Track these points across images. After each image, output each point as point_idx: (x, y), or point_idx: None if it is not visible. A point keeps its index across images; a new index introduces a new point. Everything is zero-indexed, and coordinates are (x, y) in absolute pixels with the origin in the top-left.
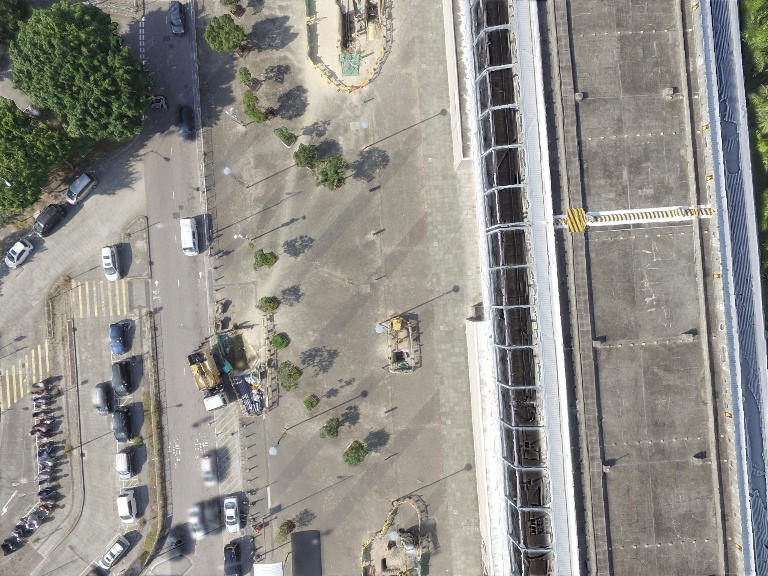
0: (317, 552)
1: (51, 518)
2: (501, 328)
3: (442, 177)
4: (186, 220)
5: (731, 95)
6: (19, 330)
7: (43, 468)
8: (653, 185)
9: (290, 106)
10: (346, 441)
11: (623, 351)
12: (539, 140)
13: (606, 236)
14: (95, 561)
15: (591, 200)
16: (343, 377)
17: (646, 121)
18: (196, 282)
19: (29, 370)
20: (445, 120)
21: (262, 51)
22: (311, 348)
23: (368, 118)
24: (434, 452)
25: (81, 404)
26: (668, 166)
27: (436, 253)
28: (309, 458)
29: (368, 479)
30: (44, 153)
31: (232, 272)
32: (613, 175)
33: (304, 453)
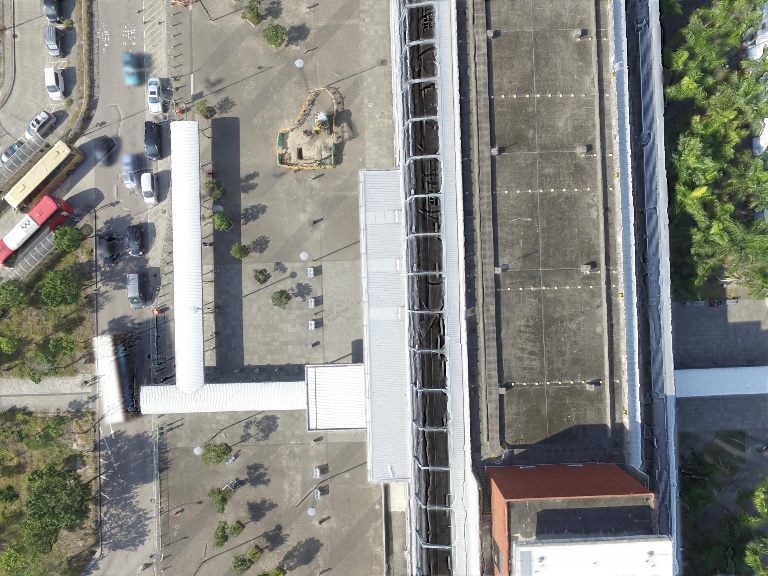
0: (236, 138)
1: None
2: None
3: None
4: None
5: None
6: None
7: None
8: None
9: None
10: None
11: None
12: None
13: None
14: (22, 137)
15: None
16: None
17: None
18: None
19: None
20: None
21: None
22: None
23: None
24: (352, 47)
25: None
26: None
27: None
28: (232, 49)
29: (288, 71)
30: None
31: None
32: None
33: (227, 44)
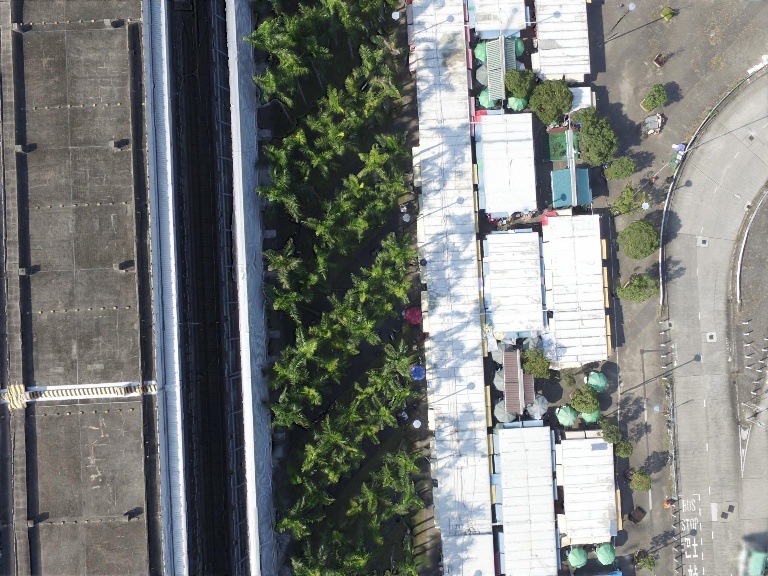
0: None
1: None
2: None
3: None
4: None
5: (233, 256)
6: None
7: None
8: (103, 360)
9: None
10: None
11: (66, 528)
12: None
13: (53, 411)
14: None
15: (39, 374)
16: None
17: (99, 295)
18: None
19: None
20: None
21: None
22: None
23: None
24: None
25: None
26: (120, 341)
27: None
28: None
29: None
30: None
31: None
32: (62, 349)
33: None
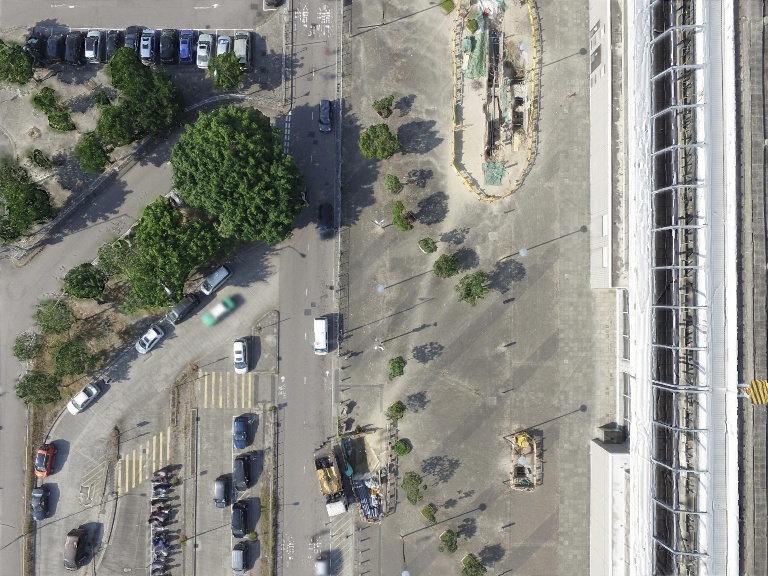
0: None
1: None
2: (649, 472)
3: (577, 294)
4: (321, 321)
5: None
6: (143, 415)
7: (157, 557)
8: None
9: (430, 211)
10: (461, 553)
11: None
12: (725, 306)
13: None
14: None
15: None
16: (463, 488)
17: None
18: (322, 381)
19: (149, 456)
20: (584, 237)
21: (406, 154)
22: (433, 456)
23: (507, 229)
24: (549, 572)
25: (198, 494)
26: None
27: (566, 370)
28: (422, 567)
29: None
30: (196, 253)
31: (359, 373)
32: None
33: (418, 562)
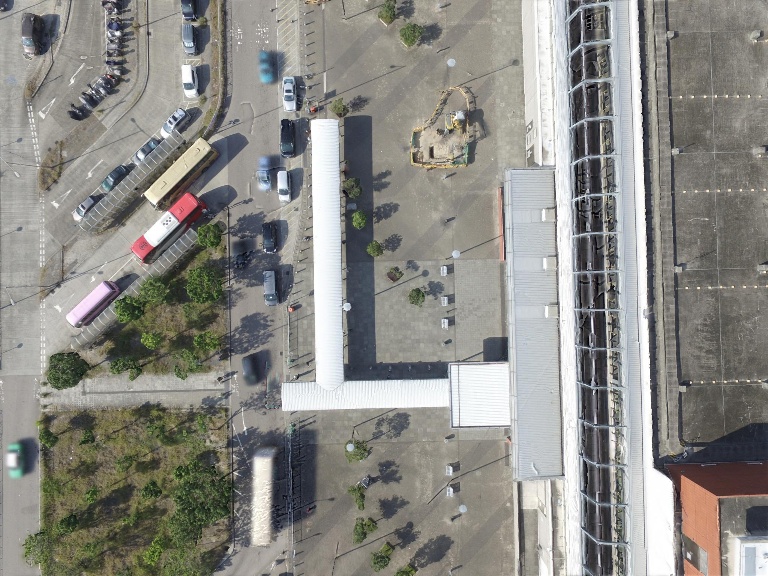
0: (368, 137)
1: (116, 91)
2: None
3: None
4: None
5: None
6: None
7: (111, 40)
8: None
9: None
10: None
11: None
12: None
13: None
14: (156, 134)
15: None
16: None
17: None
18: None
19: None
20: None
21: None
22: None
23: None
24: (484, 47)
25: None
26: None
27: None
28: (365, 48)
29: (420, 70)
30: None
31: None
32: None
33: (360, 43)
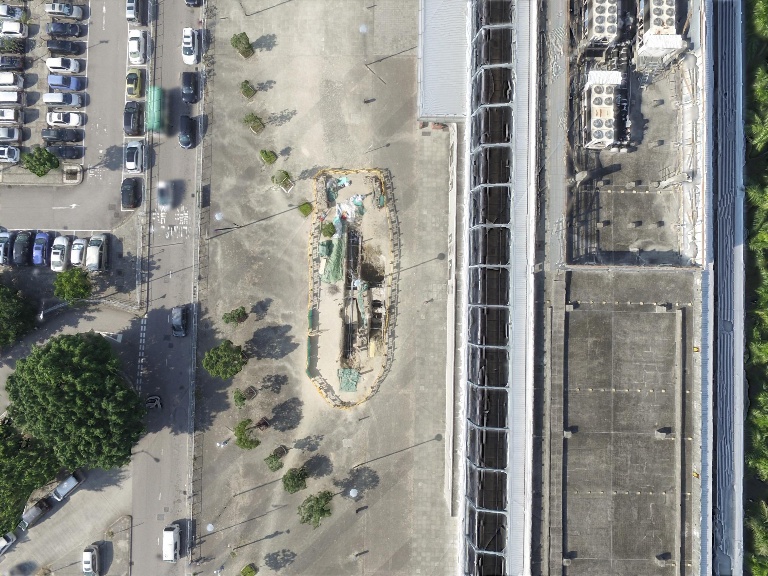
0: None
1: None
2: None
3: (431, 503)
4: (169, 533)
5: (728, 529)
6: None
7: None
8: None
9: (284, 417)
10: None
11: None
12: None
13: None
14: None
15: None
16: None
17: None
18: None
19: None
20: (439, 446)
21: (261, 359)
22: None
23: (361, 436)
24: None
25: None
26: None
27: None
28: None
29: None
30: (32, 482)
31: None
32: None
33: None
